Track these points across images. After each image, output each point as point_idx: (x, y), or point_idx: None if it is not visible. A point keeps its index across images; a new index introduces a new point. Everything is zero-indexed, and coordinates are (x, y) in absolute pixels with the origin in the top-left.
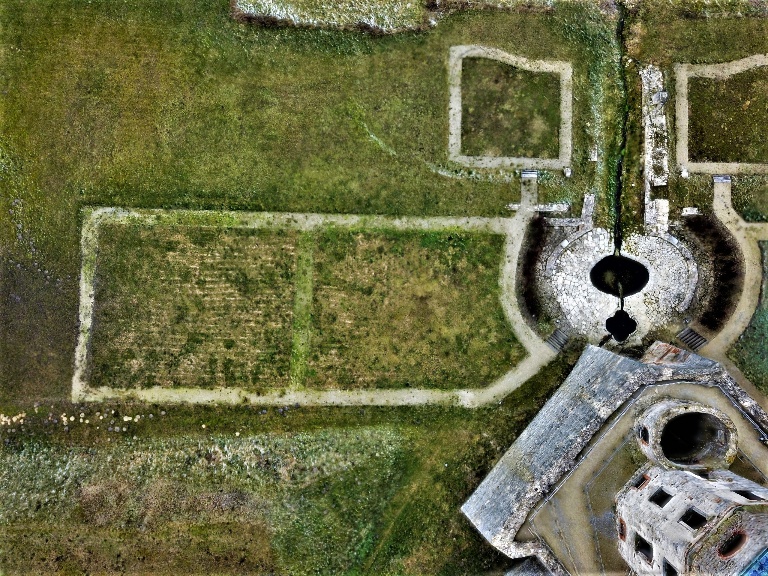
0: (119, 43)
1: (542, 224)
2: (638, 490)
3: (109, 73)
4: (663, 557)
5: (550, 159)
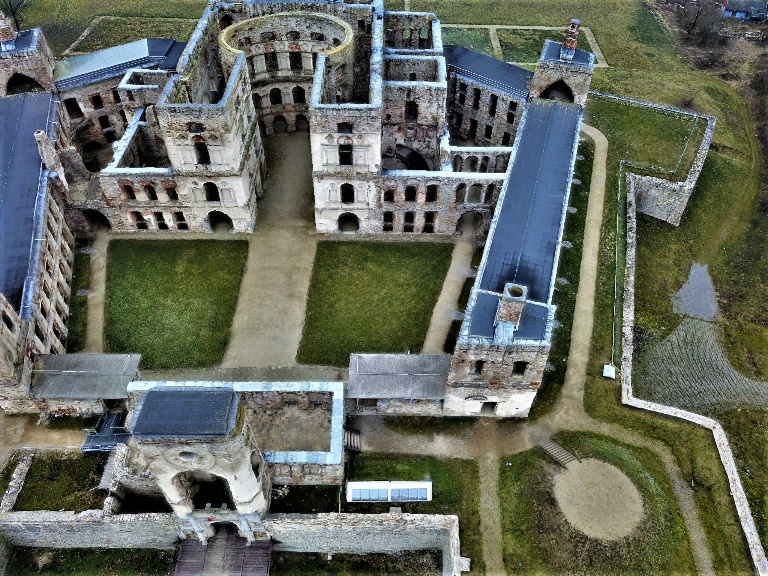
0: None
1: None
2: None
3: None
4: None
5: None
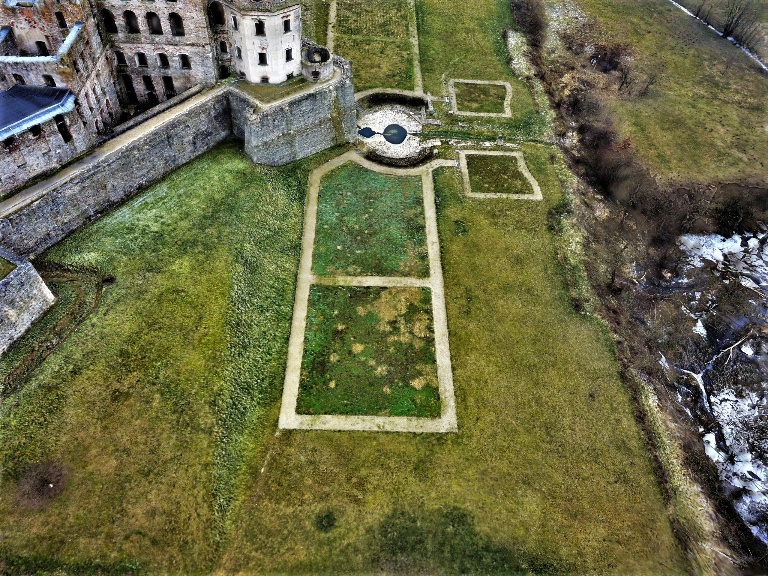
0: (485, 4)
1: (421, 106)
2: None
3: (472, 1)
4: None
5: (457, 108)
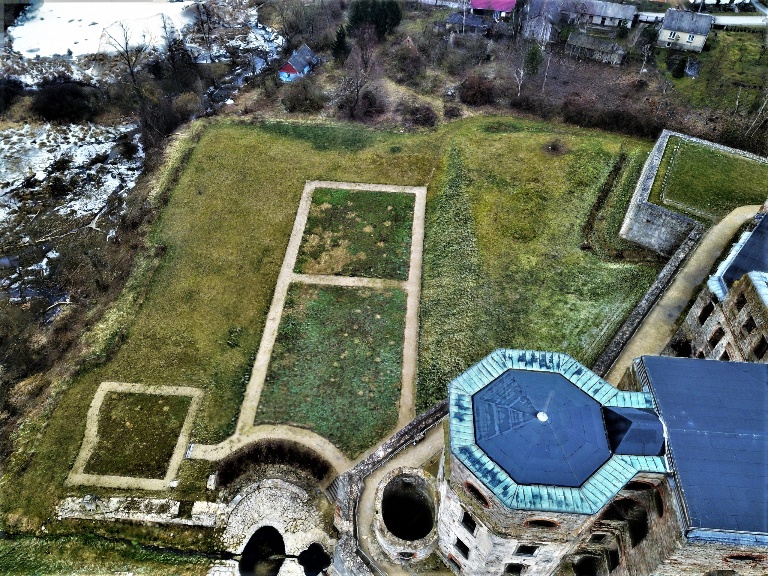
0: None
1: None
2: (462, 568)
3: None
4: (512, 556)
5: None
